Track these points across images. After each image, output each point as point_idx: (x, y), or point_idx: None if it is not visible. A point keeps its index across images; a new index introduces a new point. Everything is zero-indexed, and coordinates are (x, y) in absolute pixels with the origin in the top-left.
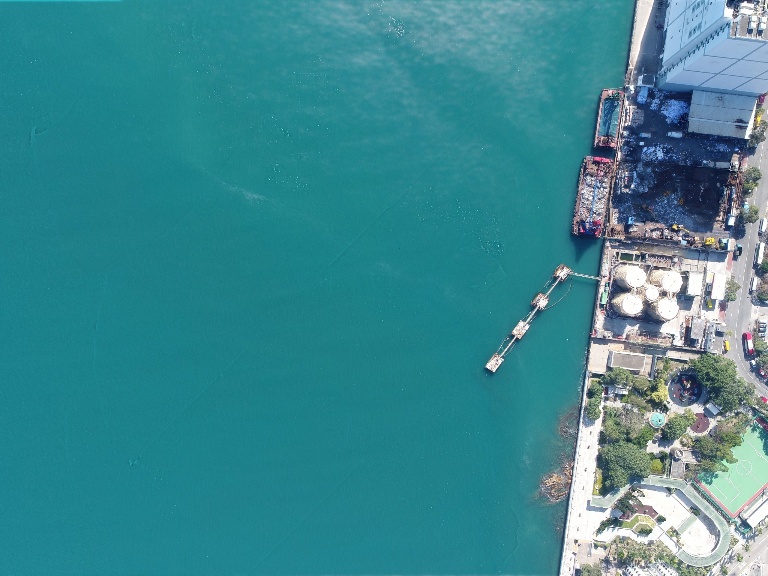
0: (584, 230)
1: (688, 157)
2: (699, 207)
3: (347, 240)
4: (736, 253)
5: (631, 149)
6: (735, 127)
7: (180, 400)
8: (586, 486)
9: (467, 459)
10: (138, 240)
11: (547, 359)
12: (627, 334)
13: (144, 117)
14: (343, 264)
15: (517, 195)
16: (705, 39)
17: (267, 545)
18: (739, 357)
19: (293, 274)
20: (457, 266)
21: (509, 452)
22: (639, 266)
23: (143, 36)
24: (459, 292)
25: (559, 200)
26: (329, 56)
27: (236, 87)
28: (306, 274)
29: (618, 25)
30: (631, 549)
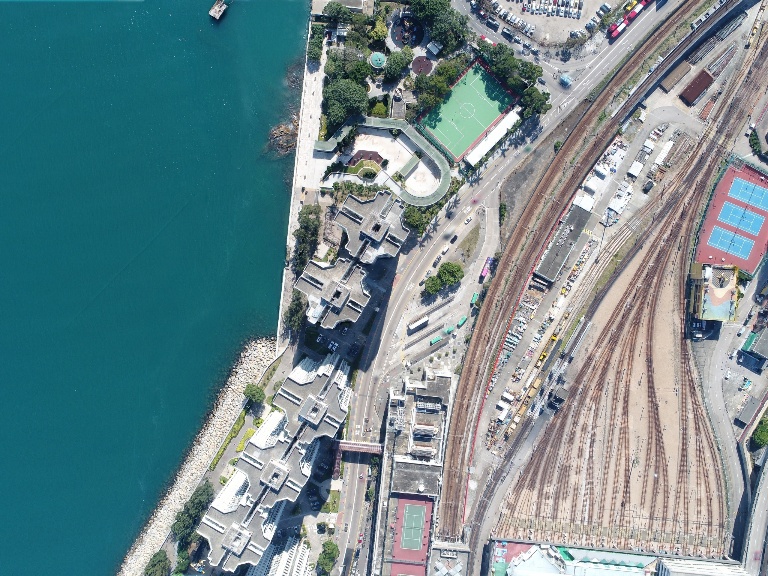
0: None
1: None
2: None
3: None
4: None
5: None
6: None
7: None
8: (312, 133)
9: (172, 82)
10: None
11: (272, 7)
12: None
13: None
14: None
15: None
16: None
17: None
18: None
19: None
20: None
21: (236, 103)
22: None
23: None
24: None
25: None
26: None
27: None
28: None
29: None
30: (348, 183)
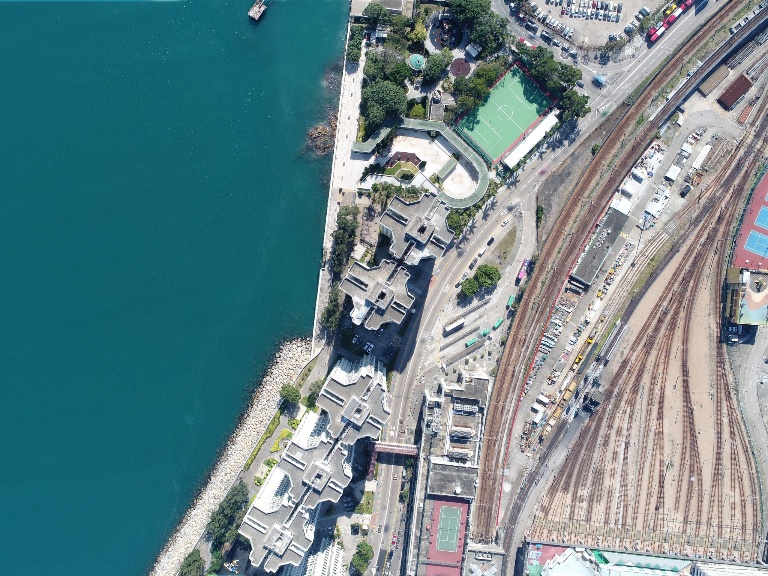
0: None
1: None
2: None
3: None
4: None
5: None
6: None
7: None
8: (350, 135)
9: (214, 82)
10: None
11: (311, 8)
12: None
13: None
14: None
15: None
16: None
17: (11, 174)
18: (499, 1)
19: None
20: None
21: (274, 104)
22: None
23: None
24: None
25: None
26: None
27: None
28: None
29: None
30: None
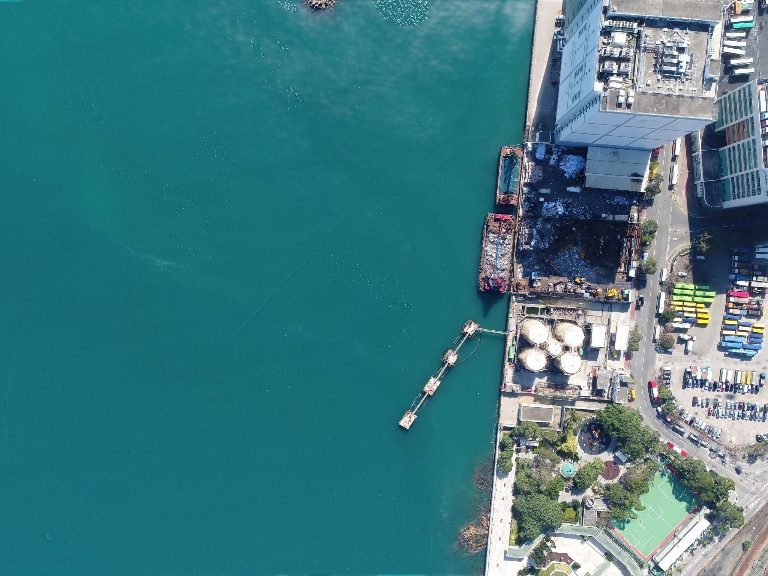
0: (489, 287)
1: (588, 211)
2: (600, 260)
3: (251, 310)
4: (638, 303)
5: (532, 205)
6: (631, 181)
7: (92, 475)
8: (502, 537)
9: (379, 520)
10: (48, 313)
11: (460, 413)
12: (536, 386)
13: (49, 189)
14: (248, 334)
15: (420, 256)
16: (585, 106)
17: None
18: (646, 404)
19: (199, 346)
20: (369, 324)
21: (426, 506)
22: (544, 320)
23: (43, 110)
24: (371, 351)
25: (464, 257)
26: (224, 129)
27: (133, 162)
28: (212, 345)
29: (515, 82)
30: None
